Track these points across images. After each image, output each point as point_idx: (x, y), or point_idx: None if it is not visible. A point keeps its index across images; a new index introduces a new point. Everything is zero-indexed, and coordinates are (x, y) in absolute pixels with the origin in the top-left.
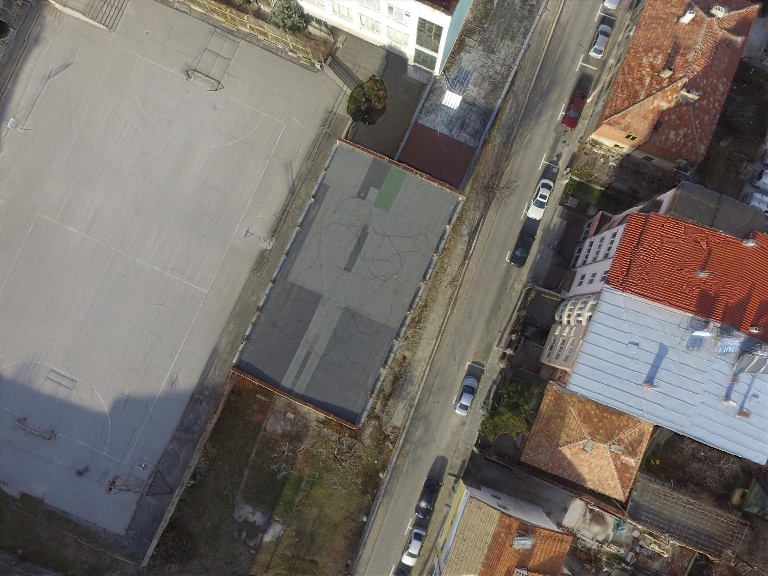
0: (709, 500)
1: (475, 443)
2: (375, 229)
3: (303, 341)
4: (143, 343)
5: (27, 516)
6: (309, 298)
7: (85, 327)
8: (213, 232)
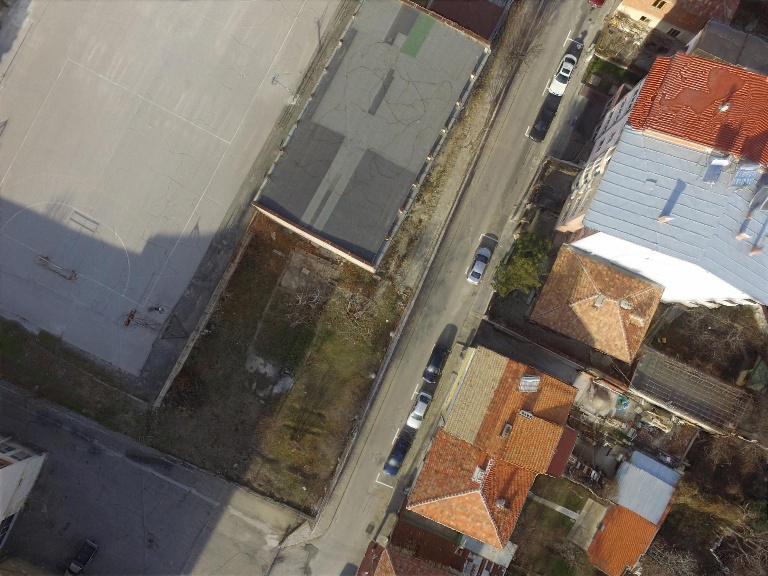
0: (713, 375)
1: (485, 313)
2: (400, 74)
3: (324, 180)
4: (165, 190)
5: (45, 352)
6: (332, 139)
7: (109, 172)
8: (239, 85)
